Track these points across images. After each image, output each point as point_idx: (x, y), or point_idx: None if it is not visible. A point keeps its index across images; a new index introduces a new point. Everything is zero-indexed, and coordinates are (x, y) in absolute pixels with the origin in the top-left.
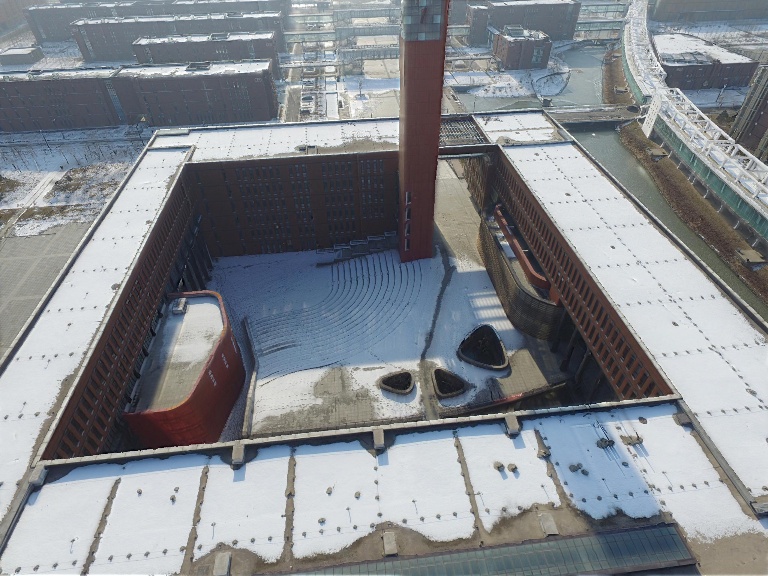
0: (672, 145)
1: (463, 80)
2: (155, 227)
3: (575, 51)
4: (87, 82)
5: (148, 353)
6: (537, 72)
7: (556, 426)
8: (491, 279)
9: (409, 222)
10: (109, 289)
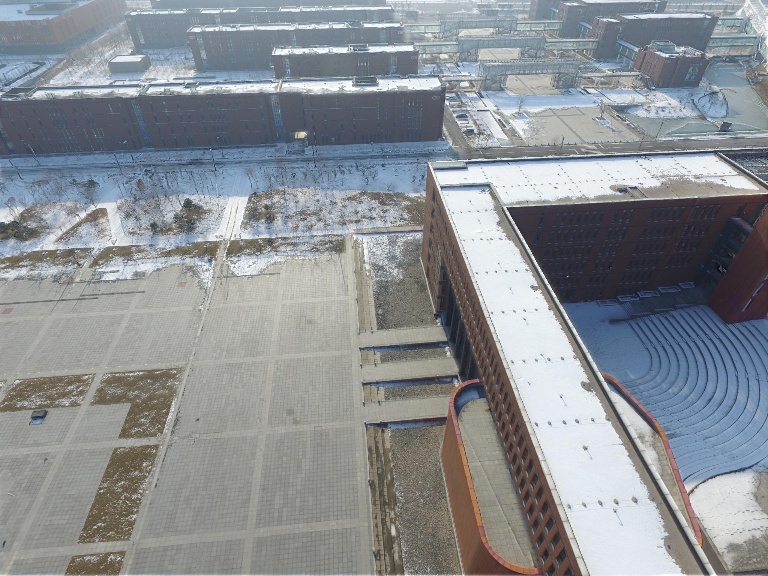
0: None
1: (617, 98)
2: None
3: (709, 68)
4: (253, 97)
5: None
6: (691, 91)
7: None
8: None
9: (766, 281)
10: (583, 390)
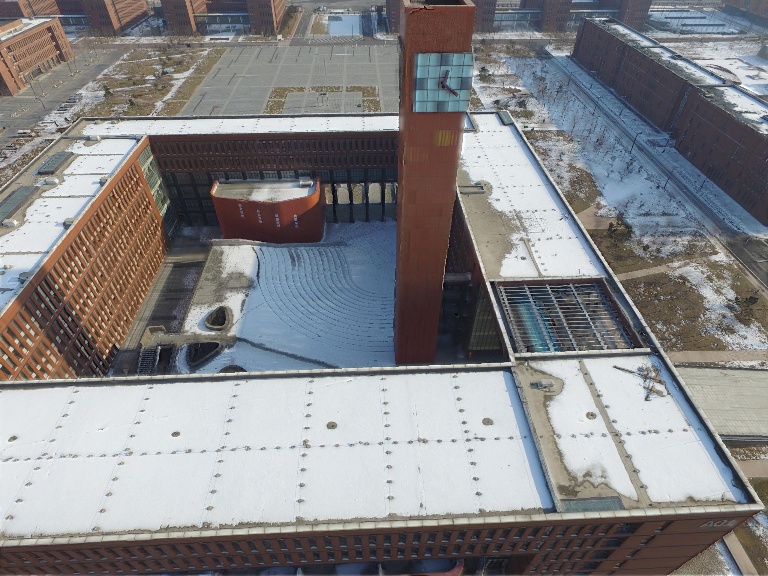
0: None
1: None
2: (337, 133)
3: None
4: (678, 80)
5: (264, 179)
6: None
7: (5, 300)
8: None
9: None
10: None
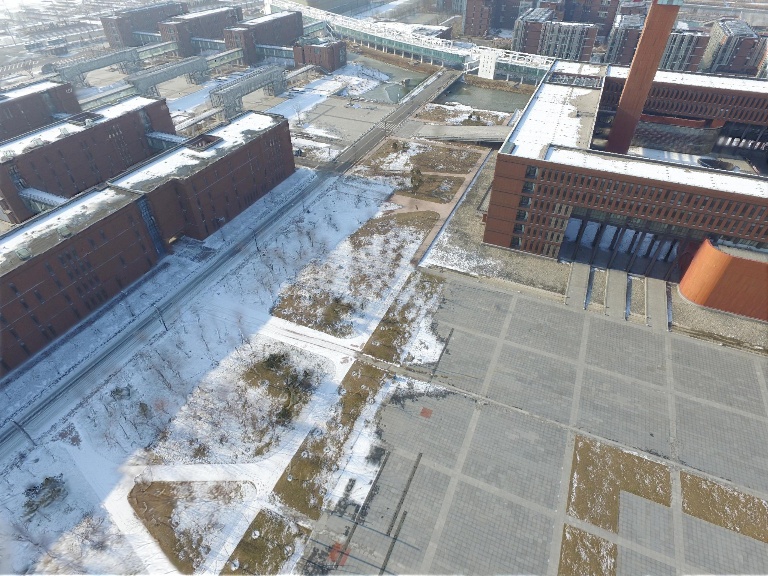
0: (527, 74)
1: (327, 88)
2: None
3: None
4: (120, 216)
5: None
6: (350, 68)
7: None
8: (654, 148)
9: None
10: None
